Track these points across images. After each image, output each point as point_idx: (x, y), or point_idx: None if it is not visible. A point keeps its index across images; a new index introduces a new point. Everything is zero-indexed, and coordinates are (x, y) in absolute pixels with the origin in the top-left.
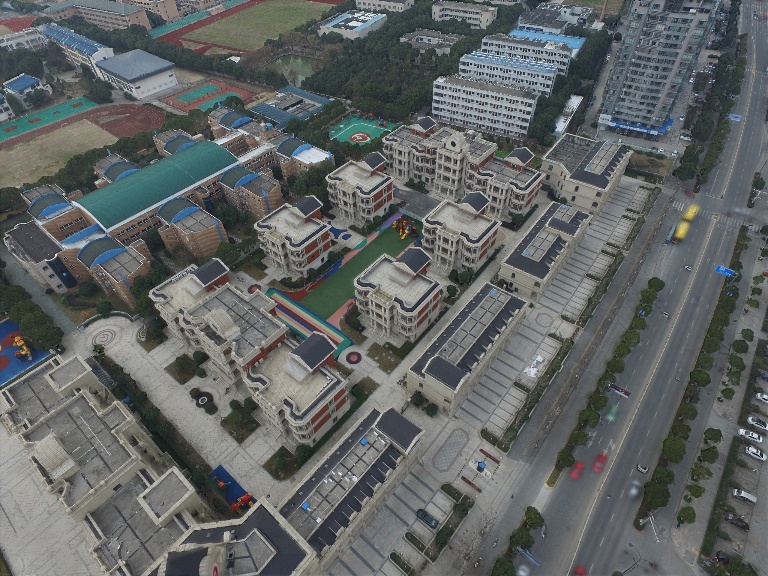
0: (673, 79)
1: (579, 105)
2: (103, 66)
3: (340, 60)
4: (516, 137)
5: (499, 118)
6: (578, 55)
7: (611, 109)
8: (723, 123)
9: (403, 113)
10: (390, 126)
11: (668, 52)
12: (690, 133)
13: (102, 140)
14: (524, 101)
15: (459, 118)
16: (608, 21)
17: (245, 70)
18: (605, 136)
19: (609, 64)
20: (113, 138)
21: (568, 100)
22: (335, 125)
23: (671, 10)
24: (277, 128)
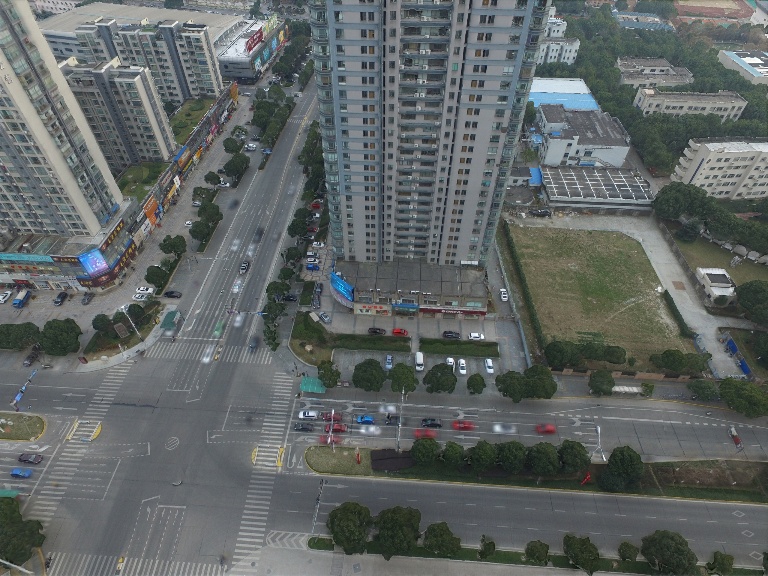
0: None
1: None
2: None
3: None
4: None
5: None
6: None
7: None
8: None
9: None
10: None
11: None
12: None
13: None
14: None
15: None
16: None
17: (729, 28)
18: None
19: None
20: (694, 5)
21: None
22: None
23: None
24: None
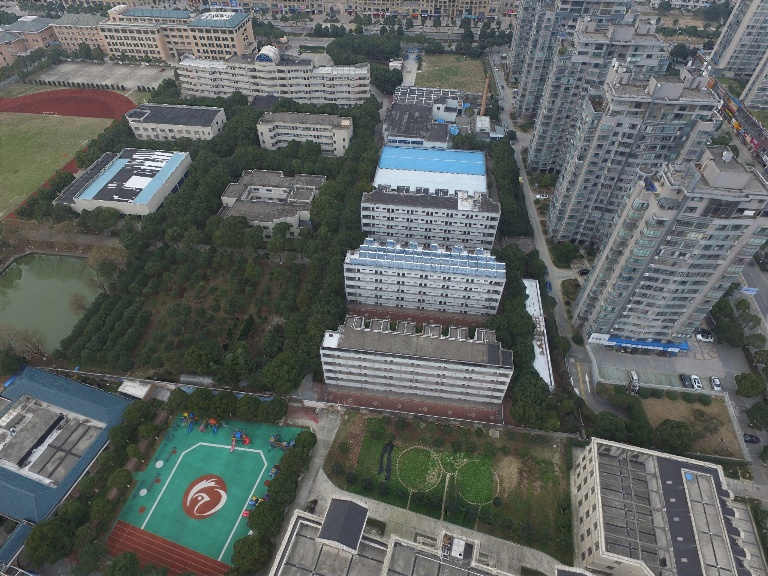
0: (708, 294)
1: (542, 303)
2: None
3: (124, 274)
4: (481, 404)
5: (450, 388)
6: (487, 185)
7: (607, 327)
8: (743, 306)
9: (276, 415)
10: (257, 437)
11: (704, 264)
12: (701, 322)
13: None
14: (495, 371)
15: (377, 388)
16: (492, 113)
17: None
18: (605, 363)
19: (526, 189)
20: None
21: (525, 300)
22: (144, 466)
23: (717, 215)
24: (3, 560)
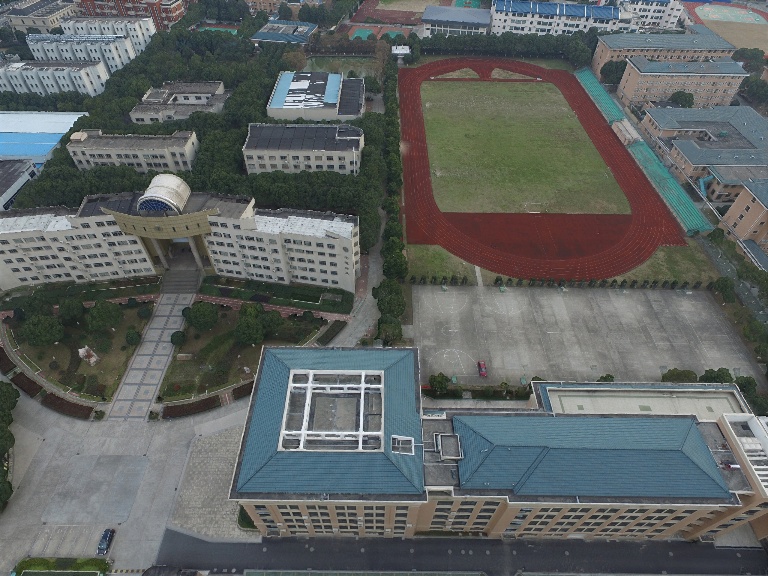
0: None
1: None
2: (475, 8)
3: None
4: None
5: None
6: None
7: None
8: None
9: None
10: None
11: None
12: None
13: (394, 7)
14: None
15: None
16: None
17: (366, 40)
18: None
19: None
20: (390, 9)
21: None
22: None
23: None
24: None
